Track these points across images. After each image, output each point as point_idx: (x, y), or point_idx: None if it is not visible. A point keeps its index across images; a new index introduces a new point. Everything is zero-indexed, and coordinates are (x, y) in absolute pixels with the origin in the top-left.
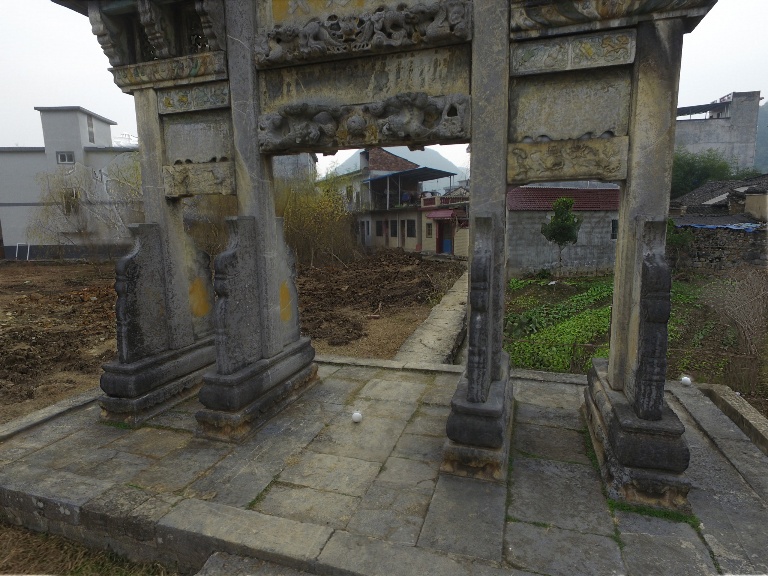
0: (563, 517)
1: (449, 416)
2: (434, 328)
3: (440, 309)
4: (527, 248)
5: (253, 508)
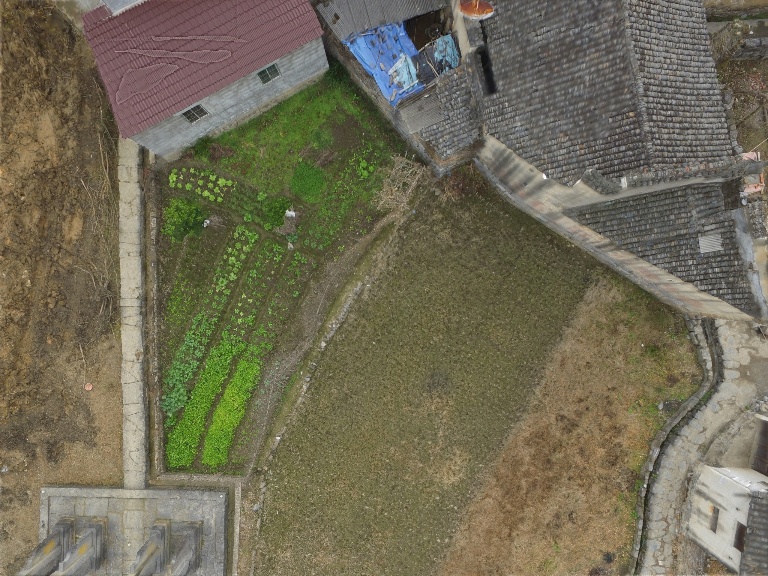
0: None
1: None
2: (131, 428)
3: (126, 381)
4: (170, 139)
5: None
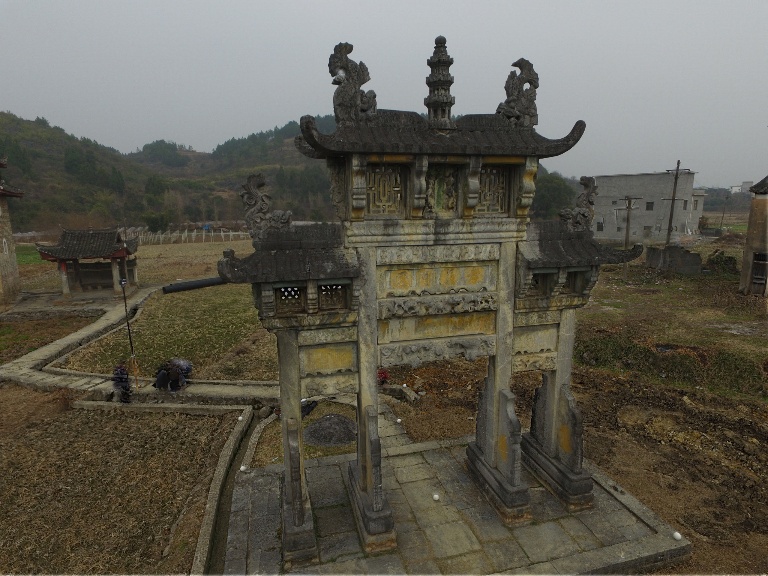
0: None
1: None
2: None
3: None
4: None
5: None
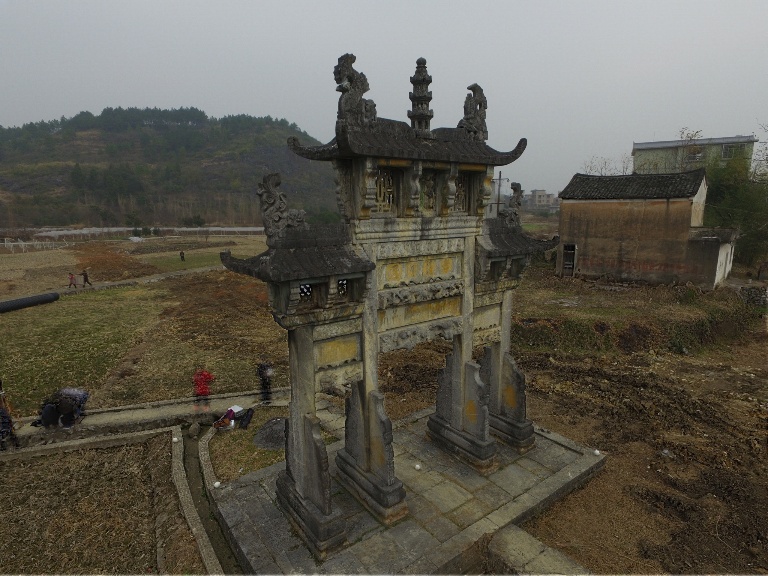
0: None
1: None
2: None
3: None
4: None
5: None
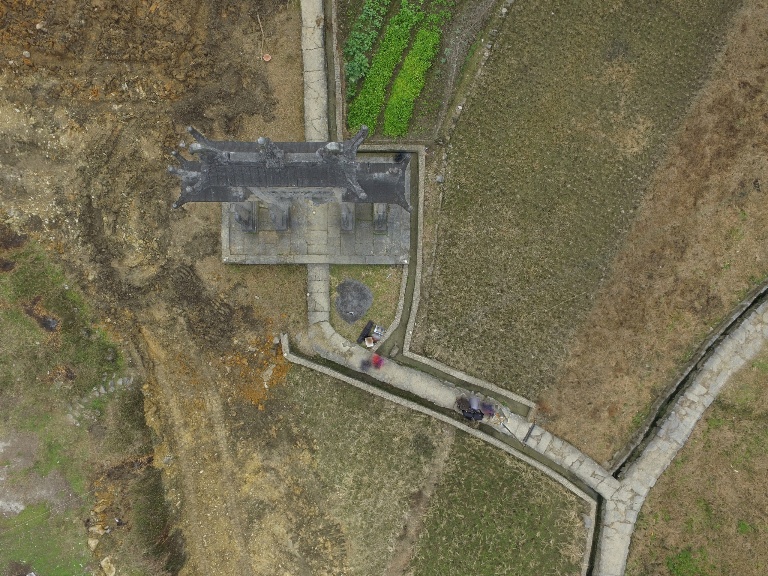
0: (365, 240)
1: (341, 229)
2: (313, 95)
3: (307, 47)
4: None
5: (308, 253)
